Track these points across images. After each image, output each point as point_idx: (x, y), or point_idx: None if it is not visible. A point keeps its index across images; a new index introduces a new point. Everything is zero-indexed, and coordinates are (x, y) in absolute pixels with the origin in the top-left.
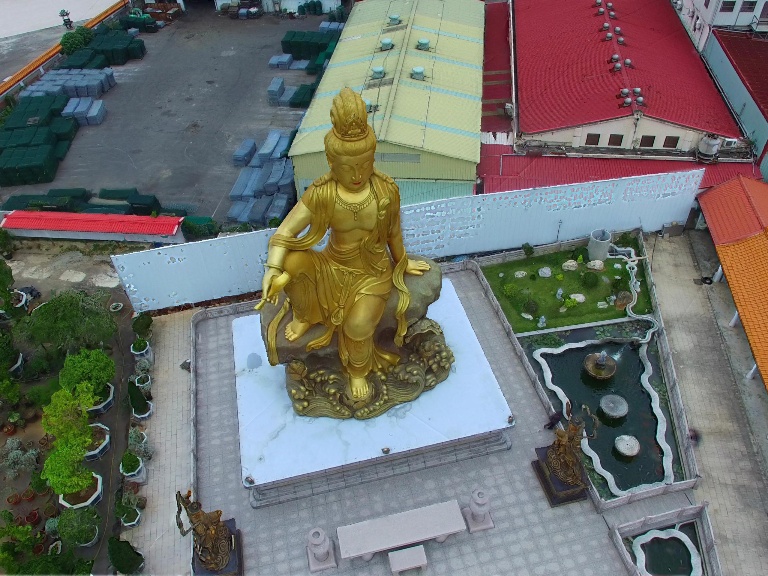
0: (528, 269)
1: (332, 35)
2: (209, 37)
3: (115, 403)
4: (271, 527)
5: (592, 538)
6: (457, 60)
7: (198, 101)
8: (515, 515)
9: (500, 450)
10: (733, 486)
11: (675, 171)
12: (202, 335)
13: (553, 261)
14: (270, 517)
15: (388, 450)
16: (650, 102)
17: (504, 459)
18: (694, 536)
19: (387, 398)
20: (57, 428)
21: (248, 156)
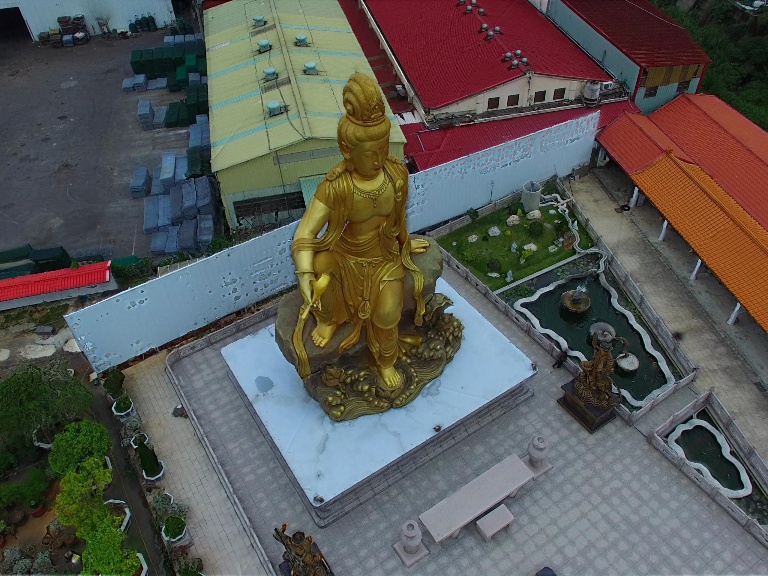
0: (477, 232)
1: (183, 48)
2: (38, 71)
3: (114, 474)
4: (348, 540)
5: (635, 449)
6: (338, 51)
7: (58, 140)
8: (565, 451)
9: (526, 399)
10: (720, 370)
11: (571, 119)
12: (182, 377)
13: (497, 220)
14: (342, 531)
15: (440, 427)
16: (531, 61)
17: (533, 406)
18: (710, 420)
19: (418, 380)
20: (77, 517)
21: (145, 185)
